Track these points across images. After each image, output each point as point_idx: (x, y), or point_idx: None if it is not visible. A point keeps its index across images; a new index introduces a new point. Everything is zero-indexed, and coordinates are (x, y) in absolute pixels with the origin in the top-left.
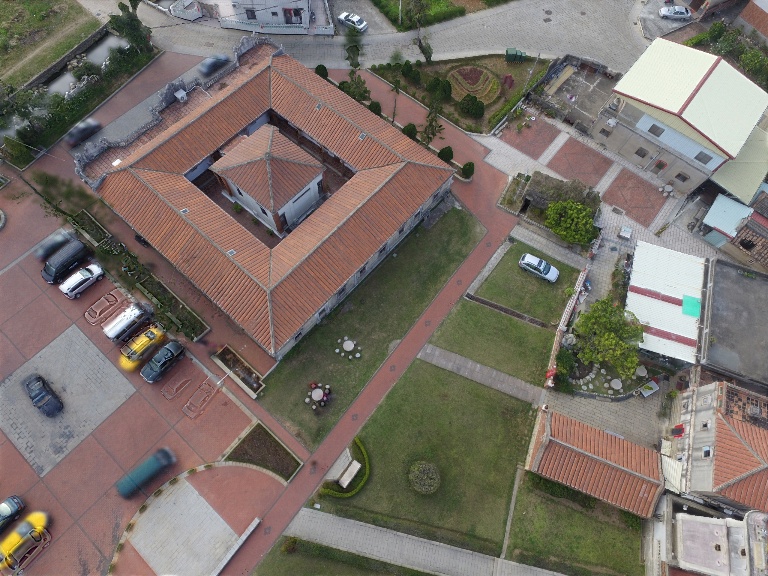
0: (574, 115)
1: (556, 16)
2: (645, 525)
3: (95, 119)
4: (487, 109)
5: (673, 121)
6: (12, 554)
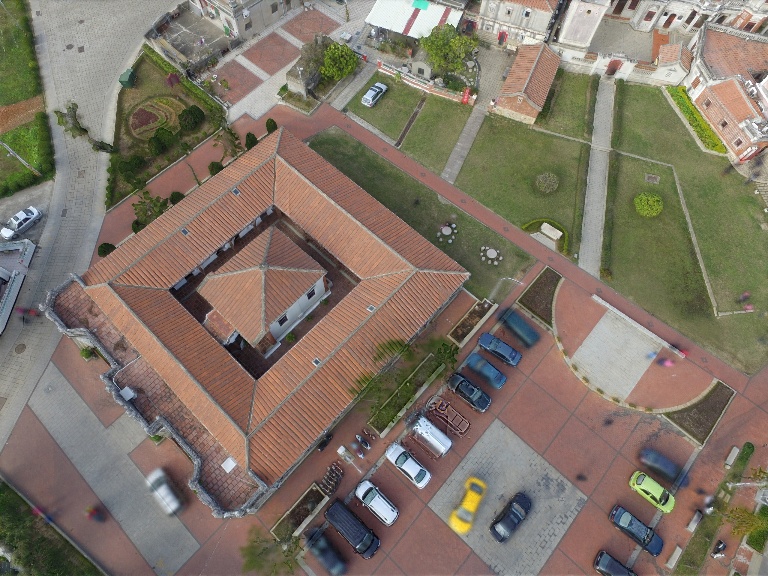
0: (217, 48)
1: (77, 42)
2: None
3: (108, 555)
4: None
5: None
6: (660, 496)
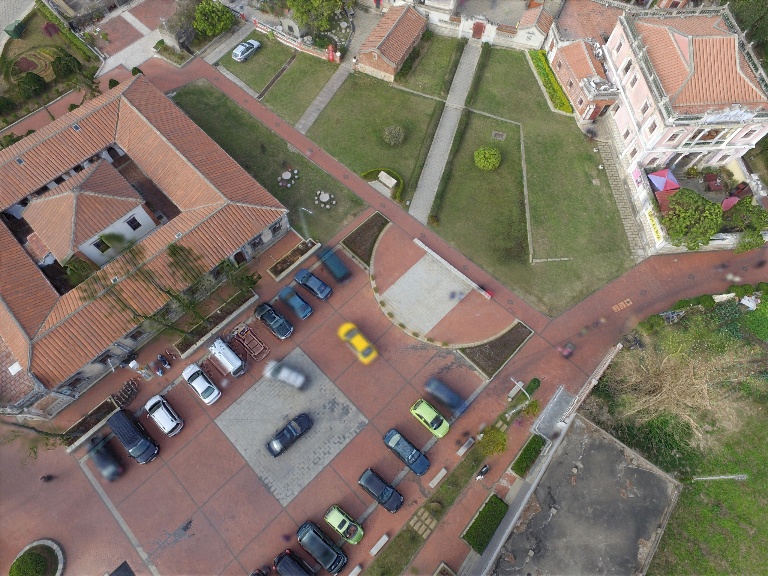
0: None
1: None
2: None
3: None
4: None
5: None
6: (431, 421)
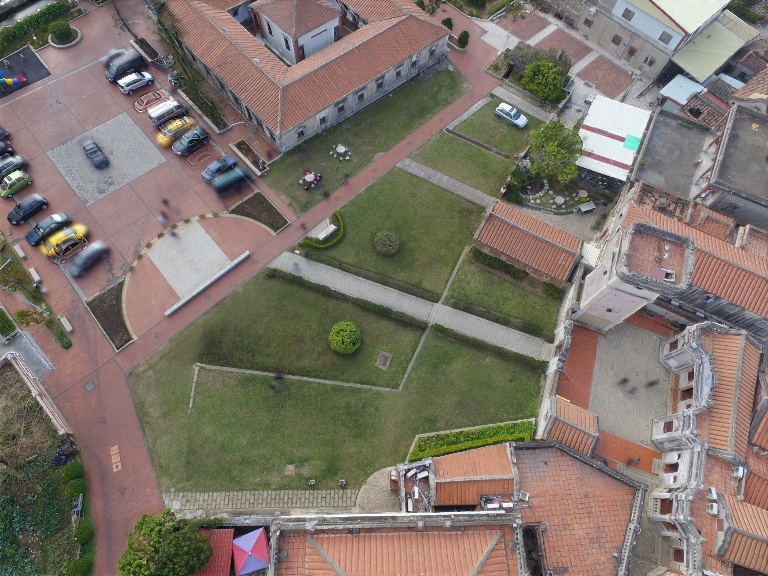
0: None
1: None
2: (563, 297)
3: None
4: (490, 2)
5: (641, 2)
6: (59, 244)
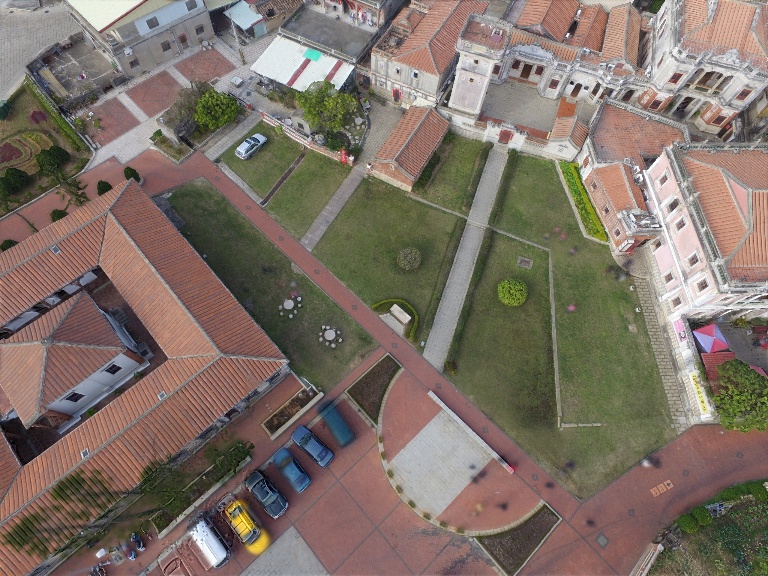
0: (101, 83)
1: None
2: (452, 132)
3: None
4: None
5: (151, 5)
6: None
